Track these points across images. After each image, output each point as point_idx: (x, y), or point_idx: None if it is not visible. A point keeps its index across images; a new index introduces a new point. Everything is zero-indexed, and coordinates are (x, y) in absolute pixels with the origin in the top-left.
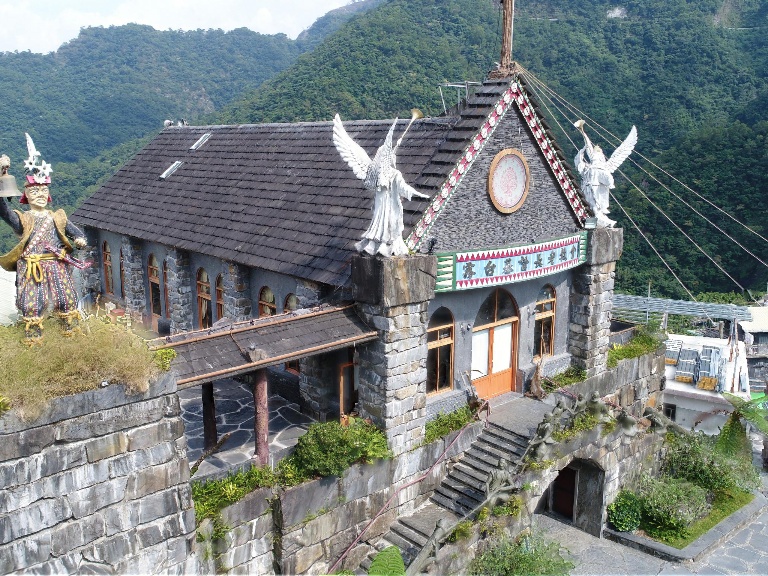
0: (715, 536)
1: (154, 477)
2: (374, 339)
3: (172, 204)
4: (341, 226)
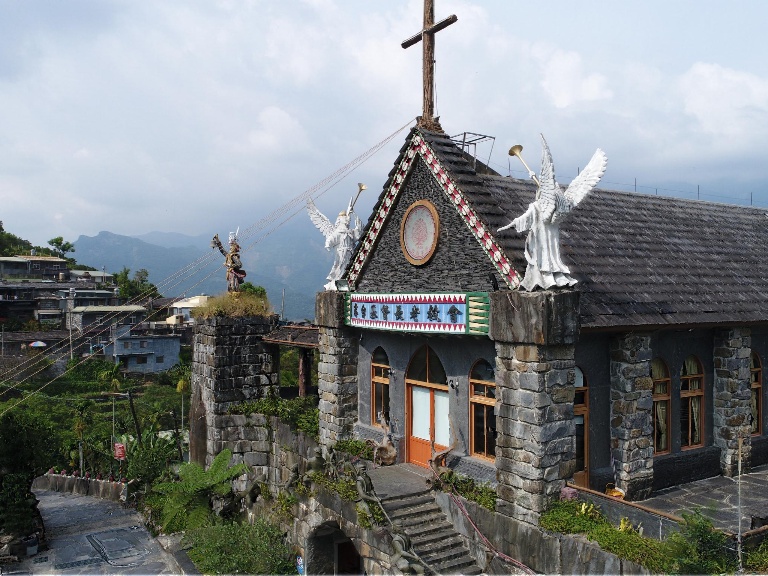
0: None
1: None
2: None
3: None
4: None
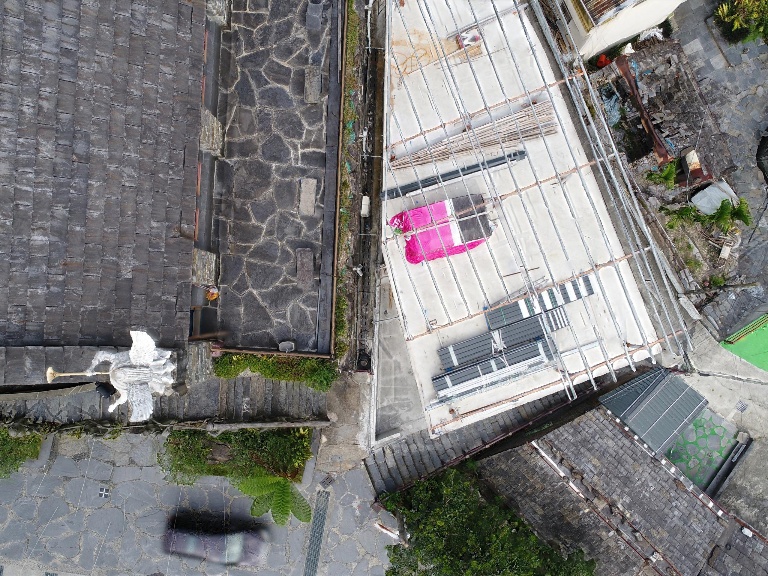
0: (210, 482)
1: None
2: None
3: None
4: None
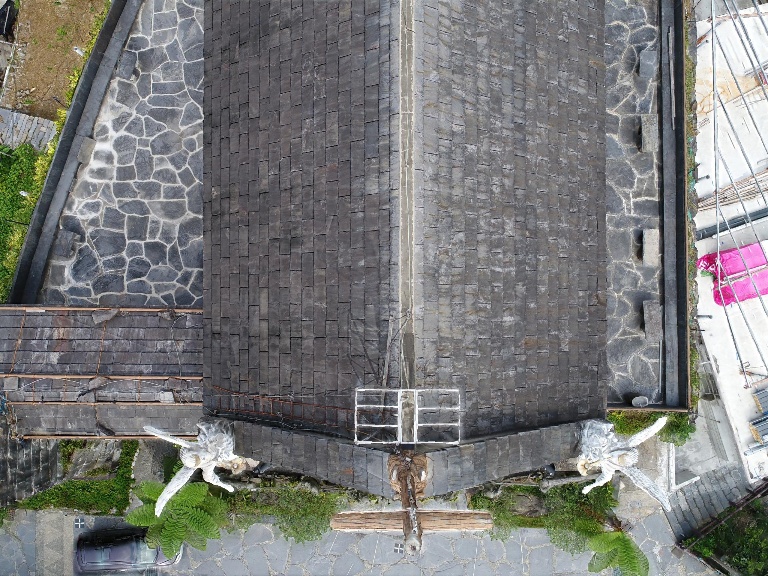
0: (510, 534)
1: None
2: None
3: None
4: (249, 335)
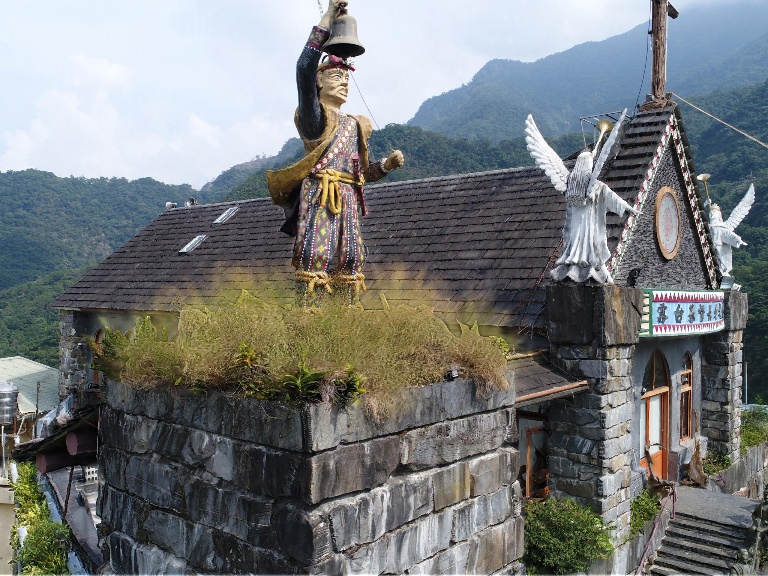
0: None
1: (492, 546)
2: (585, 390)
3: (209, 275)
4: (488, 268)
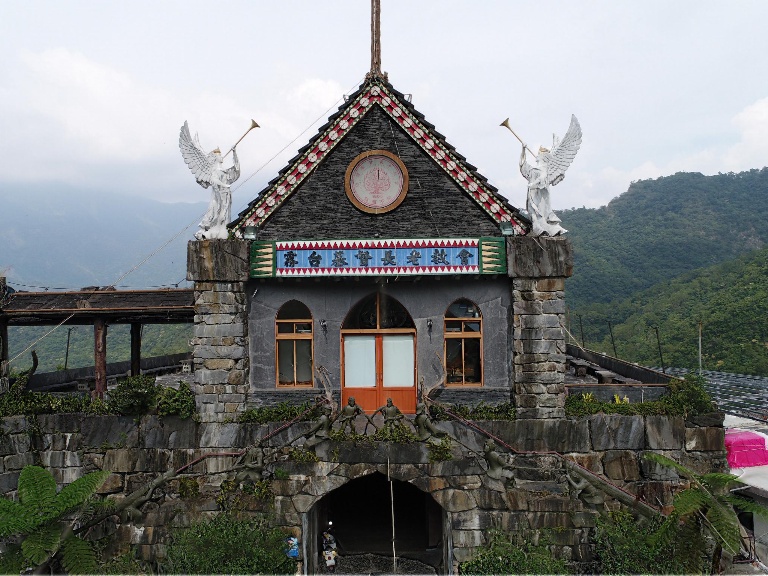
0: None
1: None
2: (192, 311)
3: None
4: None
